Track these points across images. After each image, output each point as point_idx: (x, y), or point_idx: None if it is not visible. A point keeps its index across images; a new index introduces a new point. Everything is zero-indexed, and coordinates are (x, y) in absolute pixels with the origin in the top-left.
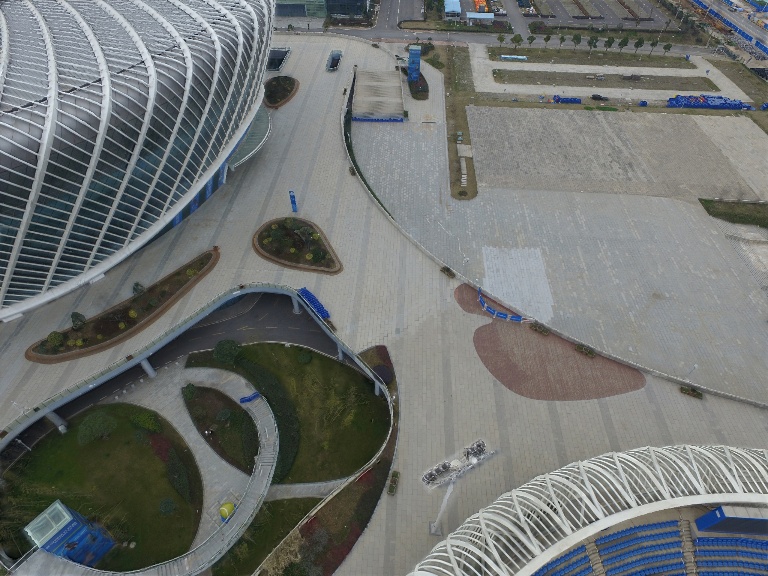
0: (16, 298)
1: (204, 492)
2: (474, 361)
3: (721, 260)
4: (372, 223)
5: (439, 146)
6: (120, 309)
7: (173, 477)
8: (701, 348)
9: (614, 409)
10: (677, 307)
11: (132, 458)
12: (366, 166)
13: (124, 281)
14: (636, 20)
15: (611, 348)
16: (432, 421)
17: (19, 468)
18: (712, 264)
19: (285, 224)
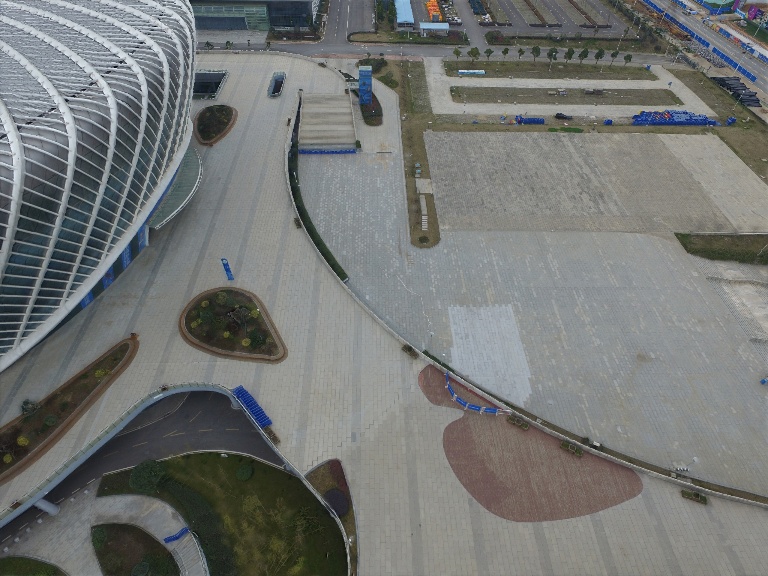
0: None
1: None
2: (445, 473)
3: (705, 307)
4: (321, 290)
5: (396, 181)
6: (7, 433)
7: None
8: (694, 422)
9: (610, 527)
10: (664, 370)
11: None
12: (315, 210)
13: (16, 390)
14: (594, 27)
15: (598, 430)
16: (398, 566)
17: None
18: (696, 313)
19: (217, 301)
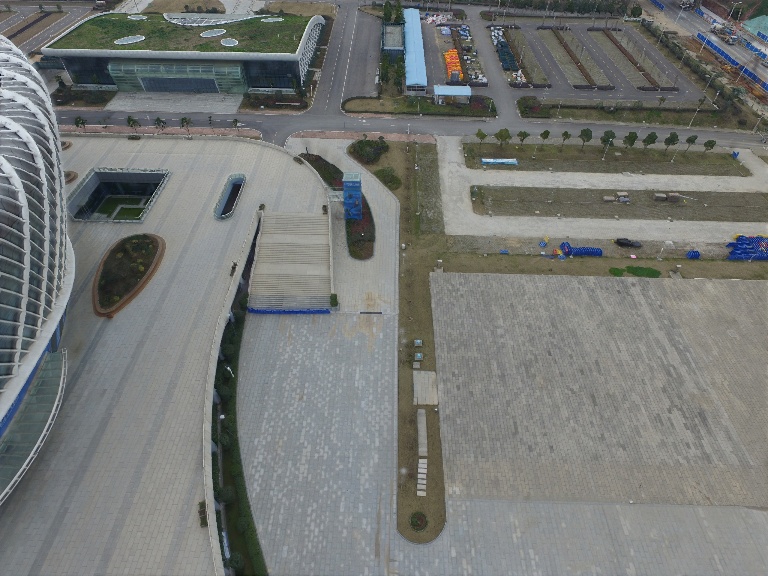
0: None
1: None
2: None
3: None
4: None
5: (383, 375)
6: None
7: None
8: None
9: None
10: None
11: None
12: (253, 439)
13: None
14: (656, 91)
15: None
16: None
17: None
18: None
19: None
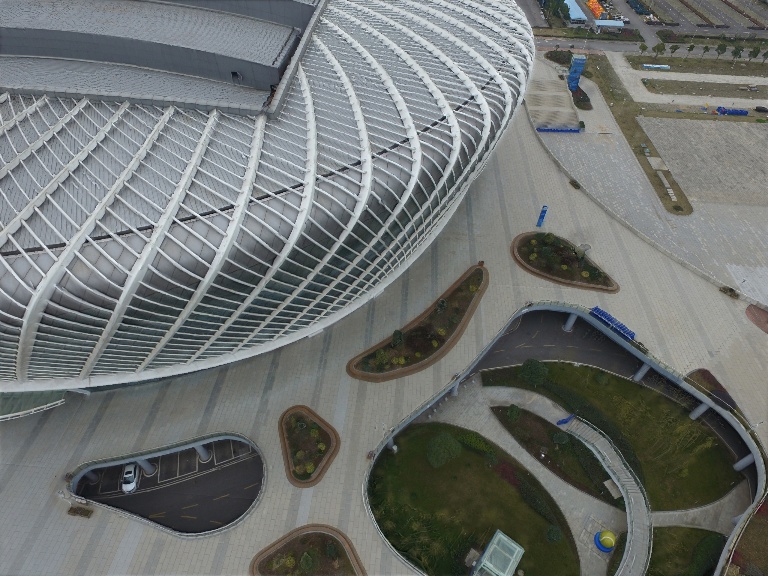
0: (327, 314)
1: (566, 518)
2: None
3: None
4: (623, 239)
5: (628, 158)
6: (422, 326)
7: (535, 502)
8: None
9: None
10: None
11: (481, 481)
12: None
13: (406, 296)
14: (764, 29)
15: None
16: None
17: (369, 489)
18: None
19: (547, 240)
